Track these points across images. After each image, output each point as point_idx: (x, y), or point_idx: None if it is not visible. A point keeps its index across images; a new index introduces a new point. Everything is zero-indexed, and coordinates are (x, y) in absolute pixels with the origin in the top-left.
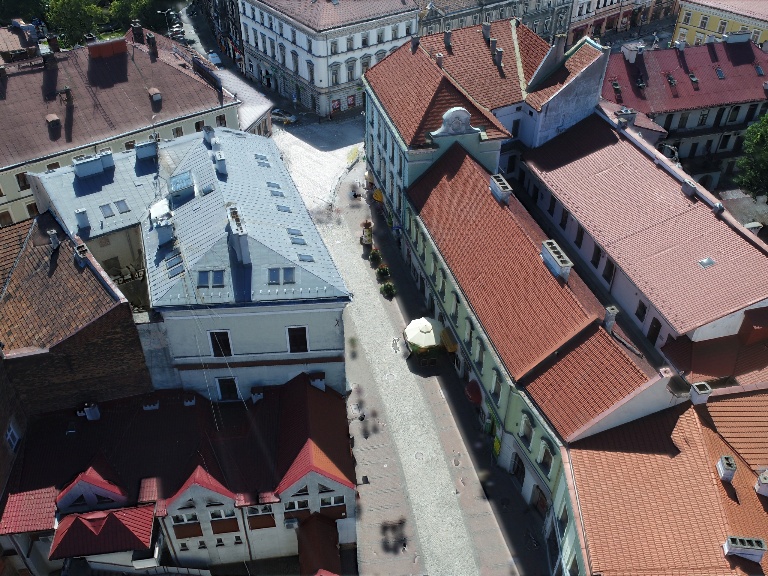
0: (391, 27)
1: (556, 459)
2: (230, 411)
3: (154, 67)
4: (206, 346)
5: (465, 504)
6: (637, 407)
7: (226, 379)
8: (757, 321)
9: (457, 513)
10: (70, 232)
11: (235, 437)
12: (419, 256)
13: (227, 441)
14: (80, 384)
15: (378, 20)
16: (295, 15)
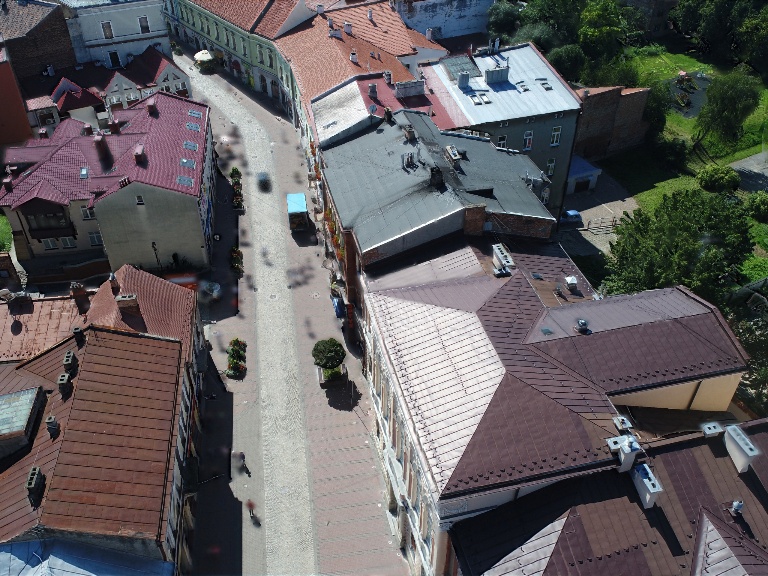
0: None
1: (273, 54)
2: (118, 70)
3: None
4: (101, 32)
5: (243, 103)
6: (297, 17)
7: (113, 53)
8: (351, 3)
9: (240, 106)
10: None
11: (126, 72)
12: (192, 25)
13: (123, 73)
14: (41, 58)
15: None
16: None
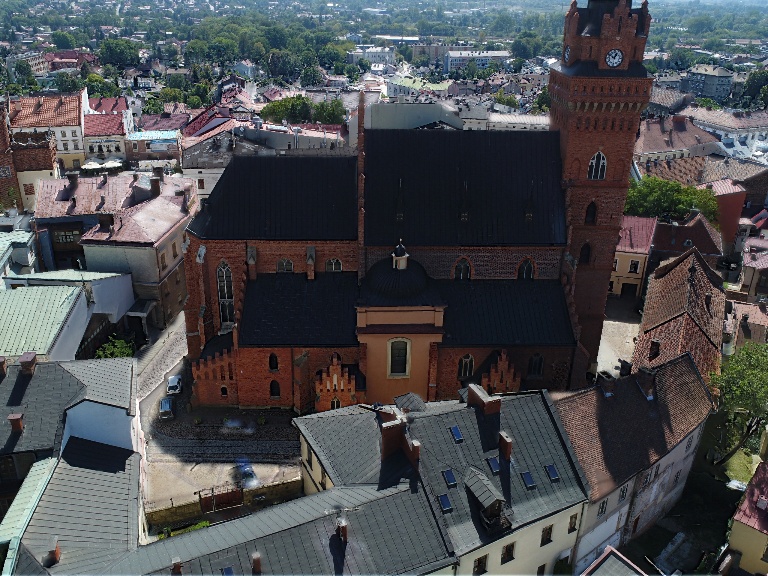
0: (766, 132)
1: None
2: None
3: (695, 128)
4: None
5: None
6: None
7: None
8: None
9: None
10: (732, 156)
11: None
12: None
13: None
14: None
15: (762, 128)
16: (718, 123)
